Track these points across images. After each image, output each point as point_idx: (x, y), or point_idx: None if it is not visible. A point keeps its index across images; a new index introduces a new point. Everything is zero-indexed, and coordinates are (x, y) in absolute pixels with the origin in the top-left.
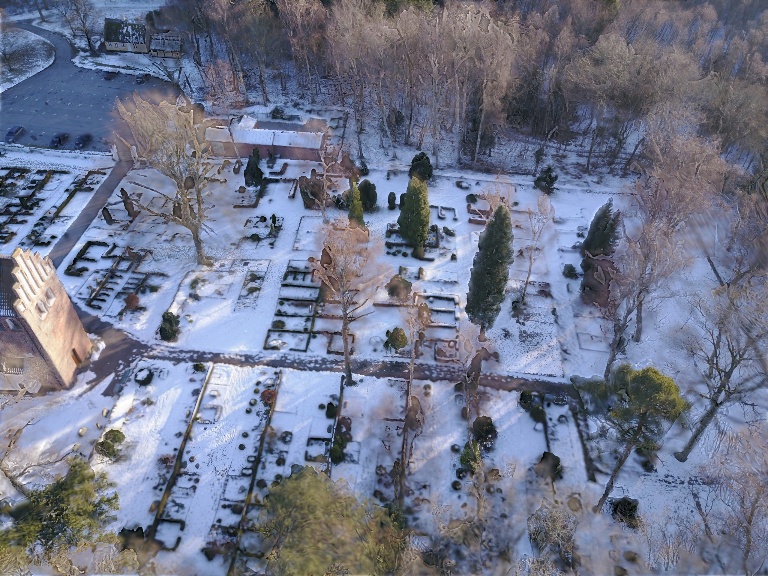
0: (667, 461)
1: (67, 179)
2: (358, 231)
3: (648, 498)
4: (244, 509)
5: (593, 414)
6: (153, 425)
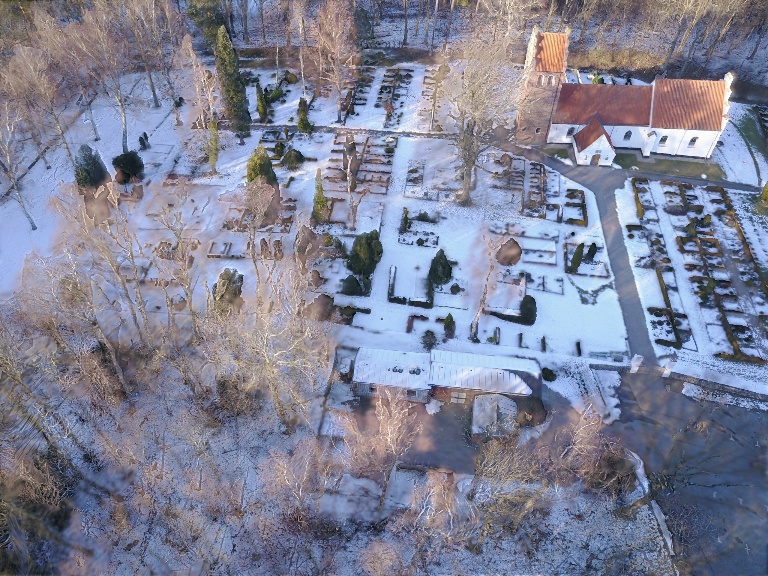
0: (167, 105)
1: (707, 344)
2: (324, 8)
3: (191, 93)
4: (395, 83)
5: (223, 22)
6: (456, 110)
